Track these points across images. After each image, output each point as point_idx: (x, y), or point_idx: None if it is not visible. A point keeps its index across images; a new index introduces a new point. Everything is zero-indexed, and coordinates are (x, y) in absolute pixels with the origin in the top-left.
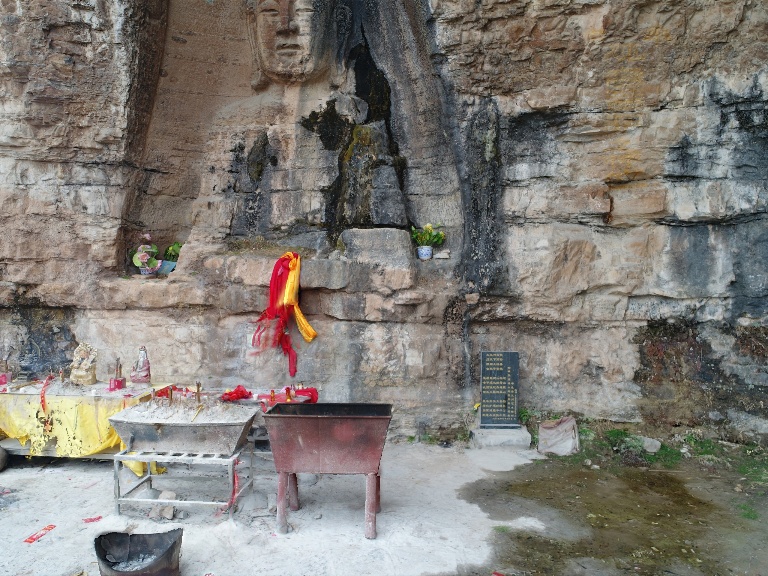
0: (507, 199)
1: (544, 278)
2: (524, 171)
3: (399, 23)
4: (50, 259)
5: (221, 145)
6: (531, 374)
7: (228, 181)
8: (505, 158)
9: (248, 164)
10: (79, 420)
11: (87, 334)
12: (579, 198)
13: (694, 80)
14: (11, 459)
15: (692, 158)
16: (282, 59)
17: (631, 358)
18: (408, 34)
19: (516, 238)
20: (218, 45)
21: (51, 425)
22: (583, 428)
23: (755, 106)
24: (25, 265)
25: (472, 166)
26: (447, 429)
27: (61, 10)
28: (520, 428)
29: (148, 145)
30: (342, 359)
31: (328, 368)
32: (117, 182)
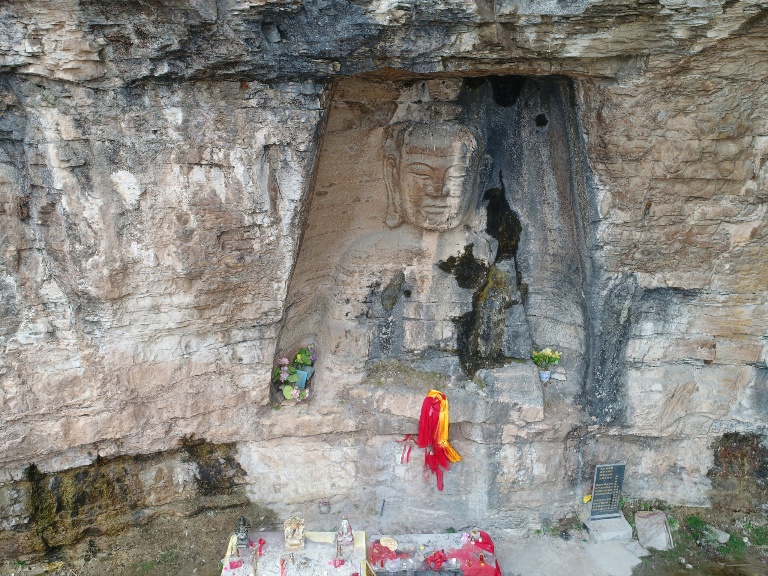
0: (630, 348)
1: (656, 416)
2: (649, 329)
3: (544, 182)
4: (215, 410)
5: (358, 282)
6: (628, 471)
7: (361, 309)
8: (634, 317)
9: (383, 298)
10: None
11: (251, 462)
12: (689, 347)
13: None
14: None
15: None
16: (429, 217)
17: (708, 460)
18: (552, 194)
19: (635, 383)
20: (355, 188)
21: None
22: (668, 516)
23: None
24: (194, 420)
25: (606, 326)
26: (563, 520)
27: (235, 218)
28: (620, 517)
29: None
30: (482, 475)
31: (471, 483)
32: (271, 336)
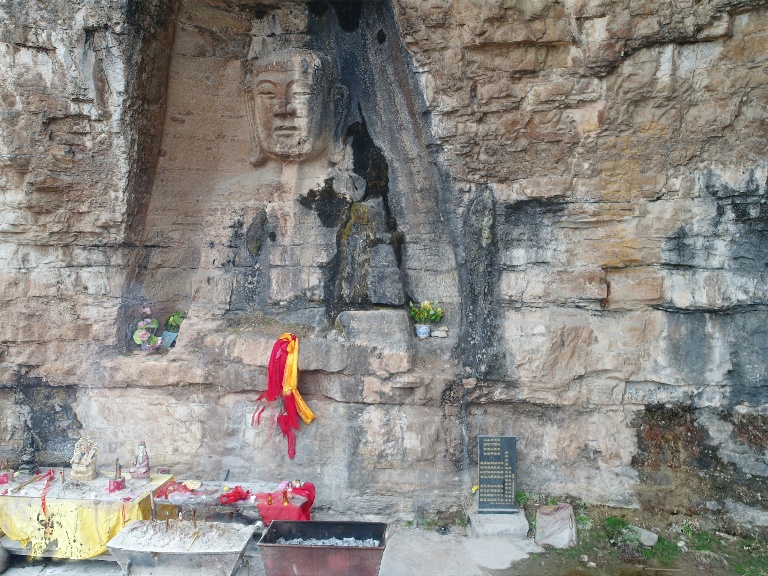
0: (504, 283)
1: (541, 365)
2: (521, 256)
3: (396, 104)
4: (52, 340)
5: (220, 221)
6: (529, 456)
7: (227, 256)
8: (502, 243)
9: (247, 240)
10: (79, 523)
11: (89, 413)
12: (576, 283)
13: (690, 172)
14: (13, 558)
15: (688, 248)
16: (280, 140)
17: (629, 442)
18: (405, 116)
19: (513, 324)
20: (217, 123)
21: (52, 528)
22: (580, 514)
23: (751, 199)
24: (27, 347)
25: (469, 251)
26: (445, 513)
27: (60, 104)
28: (518, 513)
29: (148, 223)
30: (340, 442)
31: (326, 451)
32: (117, 263)
